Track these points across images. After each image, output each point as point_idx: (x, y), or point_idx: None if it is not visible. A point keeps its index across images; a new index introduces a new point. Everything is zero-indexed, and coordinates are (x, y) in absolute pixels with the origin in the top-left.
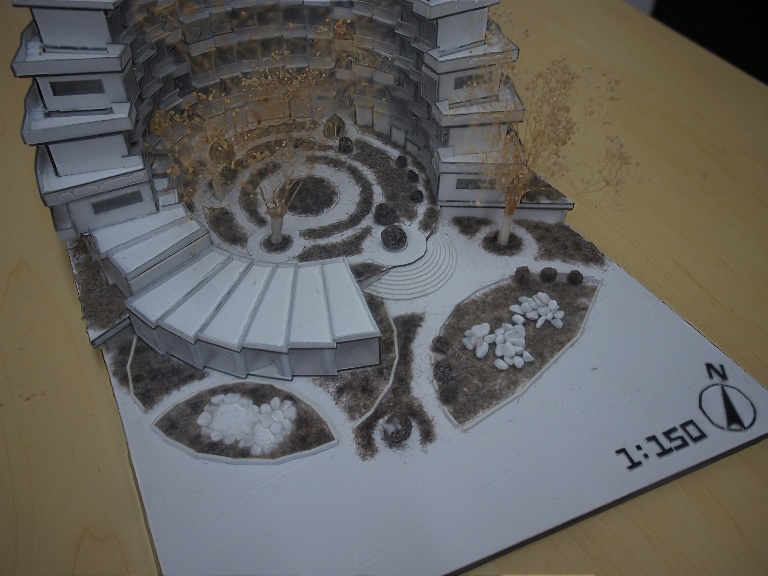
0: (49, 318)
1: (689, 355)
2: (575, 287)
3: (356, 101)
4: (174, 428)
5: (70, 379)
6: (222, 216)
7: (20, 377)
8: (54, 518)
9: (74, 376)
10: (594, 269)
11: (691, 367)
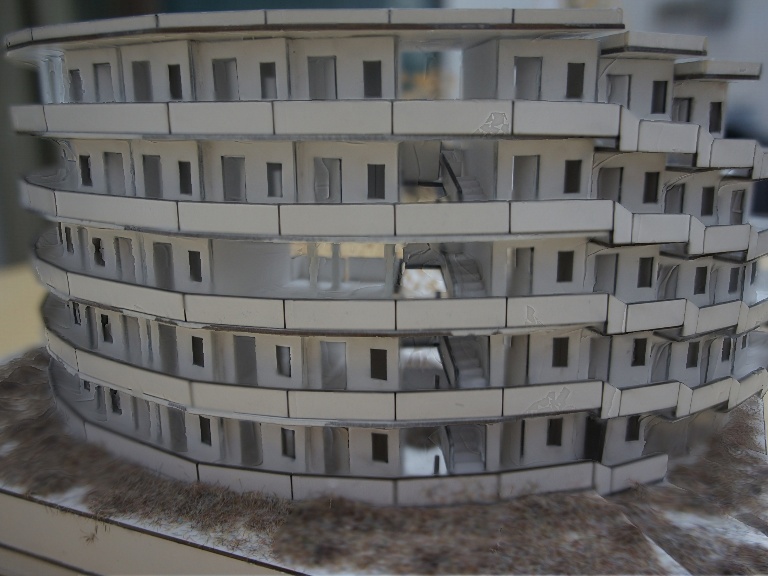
0: None
1: None
2: None
3: None
4: None
5: None
6: None
7: None
8: None
9: None
10: None
11: None
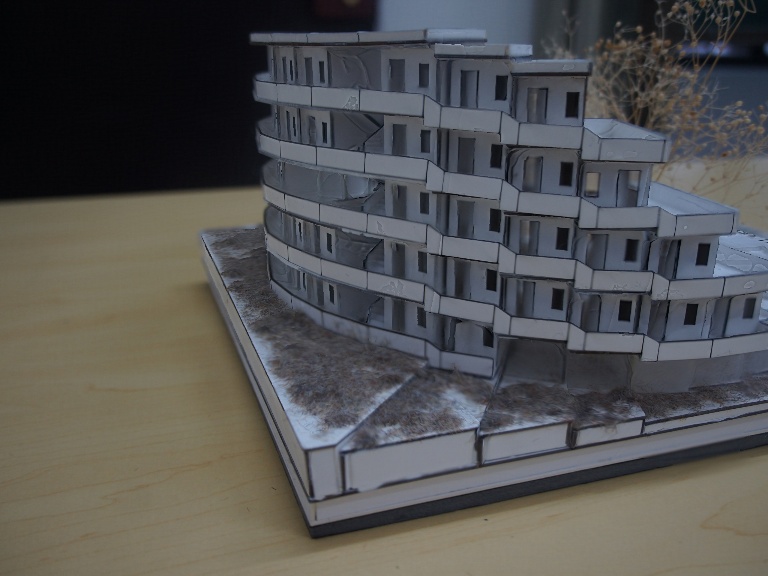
0: None
1: None
2: None
3: None
4: None
5: None
6: None
7: None
8: None
9: None
10: None
11: None
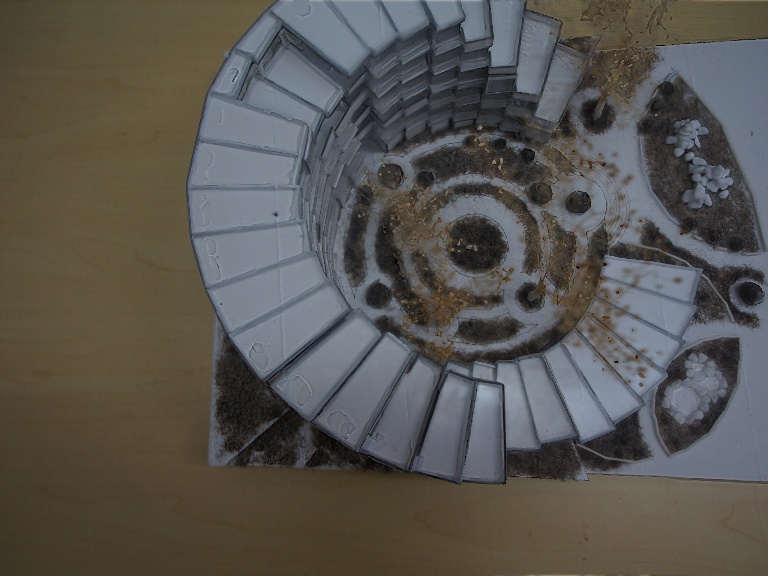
0: (504, 507)
1: (767, 62)
2: (674, 94)
3: None
4: (677, 442)
5: (581, 504)
6: (473, 329)
7: (561, 541)
8: (704, 540)
9: (579, 500)
10: (658, 66)
11: None
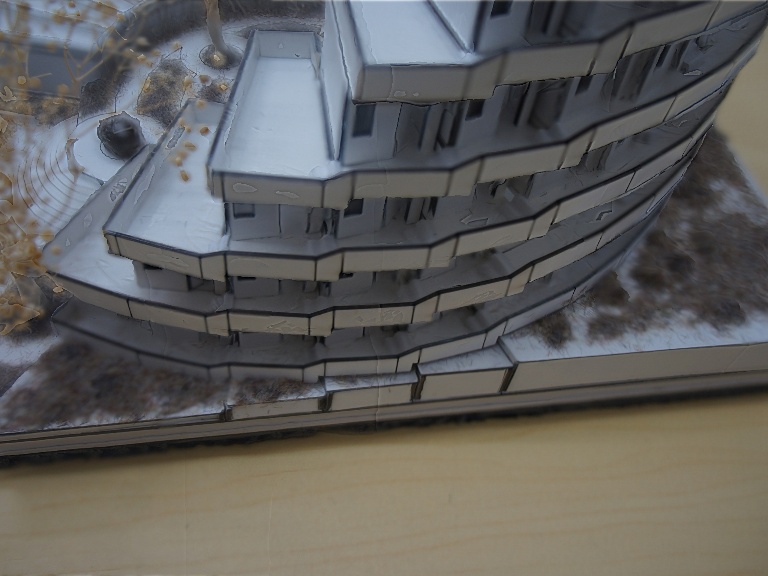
0: None
1: None
2: None
3: None
4: None
5: None
6: None
7: None
8: None
9: None
10: None
11: None
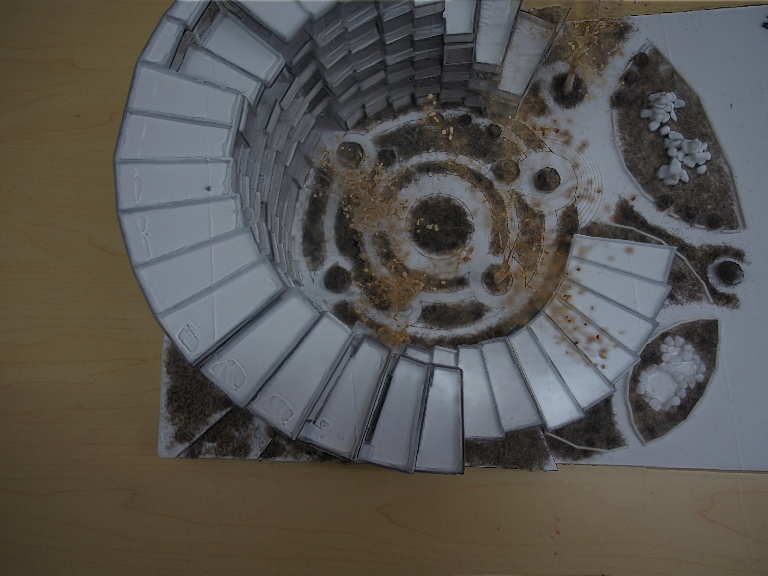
0: (471, 499)
1: (748, 31)
2: (649, 66)
3: (346, 117)
4: (653, 429)
5: (552, 496)
6: (437, 313)
7: (531, 535)
8: (682, 533)
9: (550, 492)
10: (632, 37)
11: (758, 38)
